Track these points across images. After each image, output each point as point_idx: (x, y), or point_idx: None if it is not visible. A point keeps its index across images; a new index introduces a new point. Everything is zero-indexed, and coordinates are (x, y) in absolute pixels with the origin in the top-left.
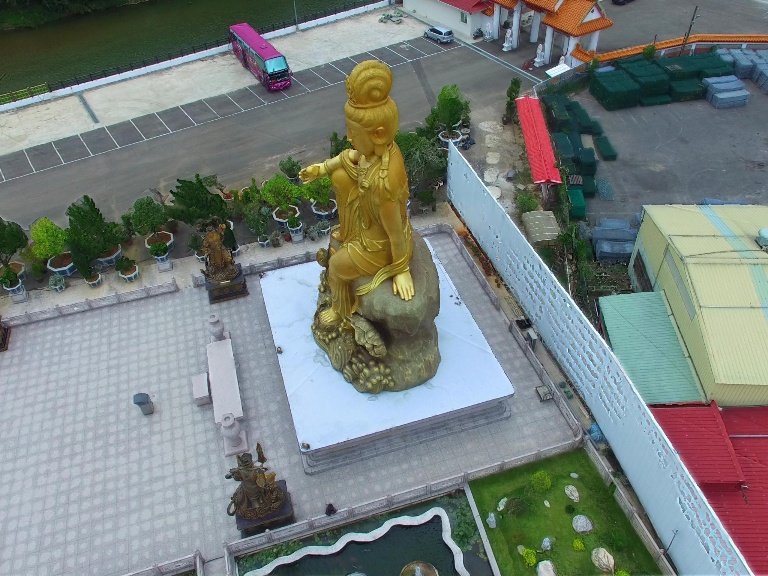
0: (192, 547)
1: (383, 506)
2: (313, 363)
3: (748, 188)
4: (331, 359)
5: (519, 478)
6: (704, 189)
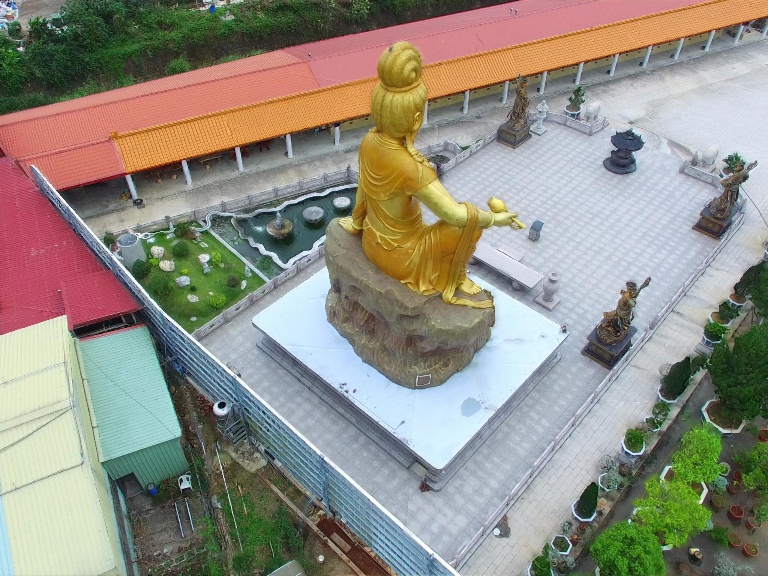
0: None
1: None
2: None
3: None
4: None
5: None
6: None
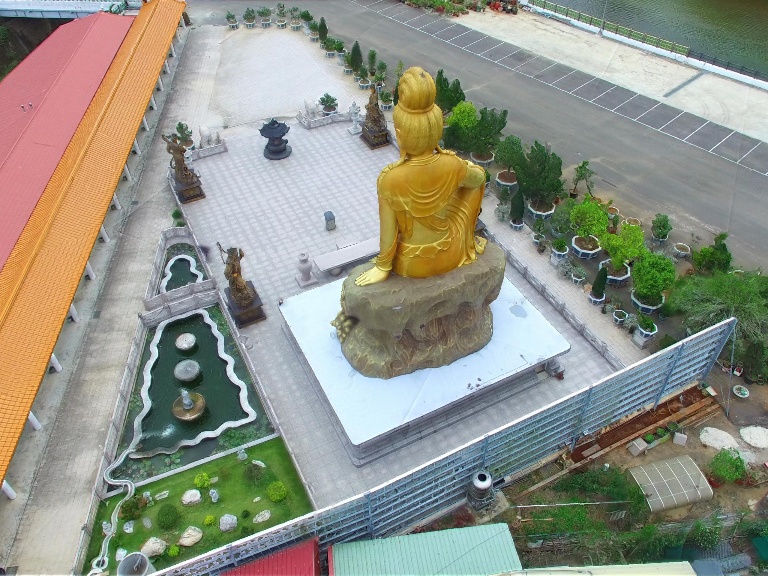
0: (226, 280)
1: None
2: None
3: None
4: None
5: (287, 478)
6: None
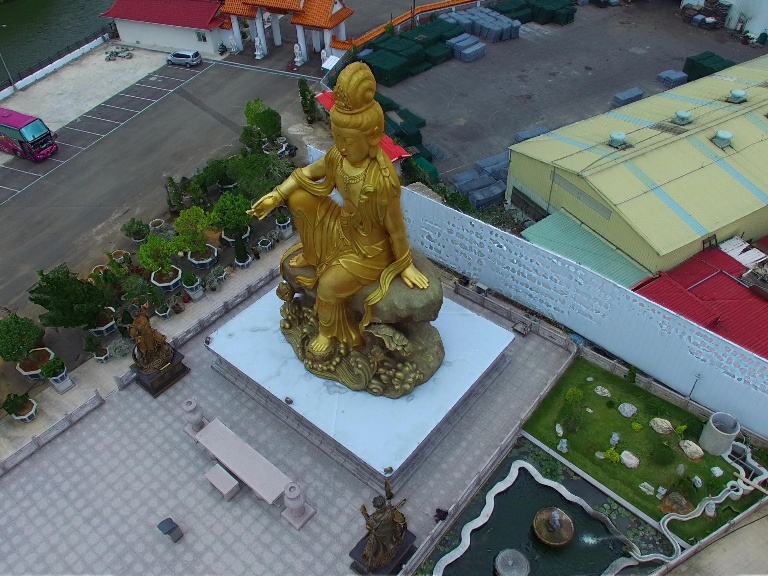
0: None
1: (475, 486)
2: (330, 396)
3: (533, 117)
4: (346, 384)
5: (554, 404)
6: (505, 127)
